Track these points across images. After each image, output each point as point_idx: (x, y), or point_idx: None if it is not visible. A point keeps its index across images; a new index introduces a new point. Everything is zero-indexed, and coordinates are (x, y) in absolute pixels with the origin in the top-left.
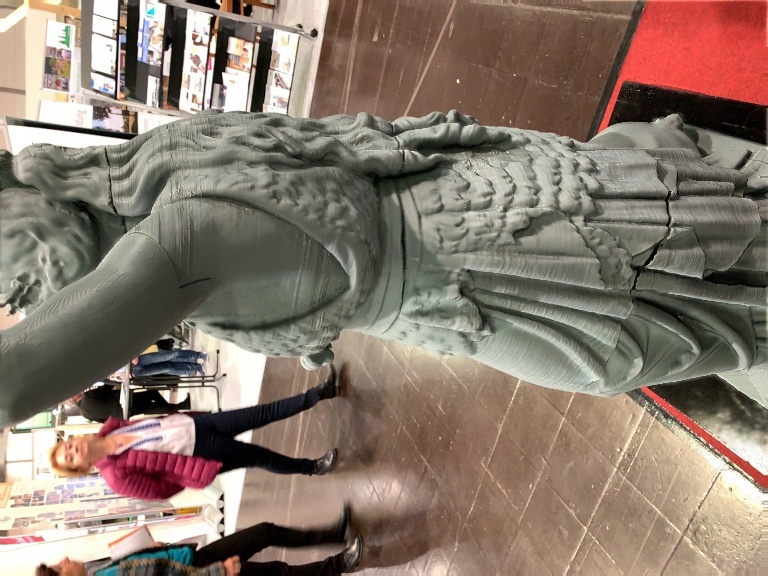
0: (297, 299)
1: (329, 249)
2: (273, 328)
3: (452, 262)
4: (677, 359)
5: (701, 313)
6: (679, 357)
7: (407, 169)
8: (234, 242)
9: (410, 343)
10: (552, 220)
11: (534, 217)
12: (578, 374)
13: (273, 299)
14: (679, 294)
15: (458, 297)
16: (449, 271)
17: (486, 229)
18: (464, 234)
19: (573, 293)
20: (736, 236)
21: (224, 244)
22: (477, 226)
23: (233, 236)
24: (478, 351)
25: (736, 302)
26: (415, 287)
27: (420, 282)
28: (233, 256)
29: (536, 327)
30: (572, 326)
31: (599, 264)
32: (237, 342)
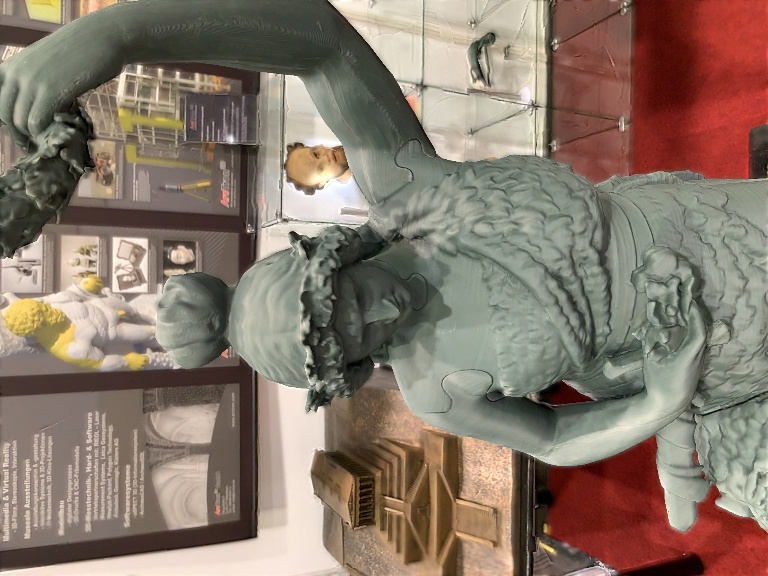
0: None
1: None
2: None
3: None
4: None
5: None
6: None
7: None
8: None
9: (666, 200)
10: None
11: None
12: None
13: None
14: None
15: None
16: None
17: None
18: None
19: None
20: None
21: None
22: None
23: None
24: None
25: None
26: None
27: None
28: None
29: None
30: None
31: None
32: (503, 168)
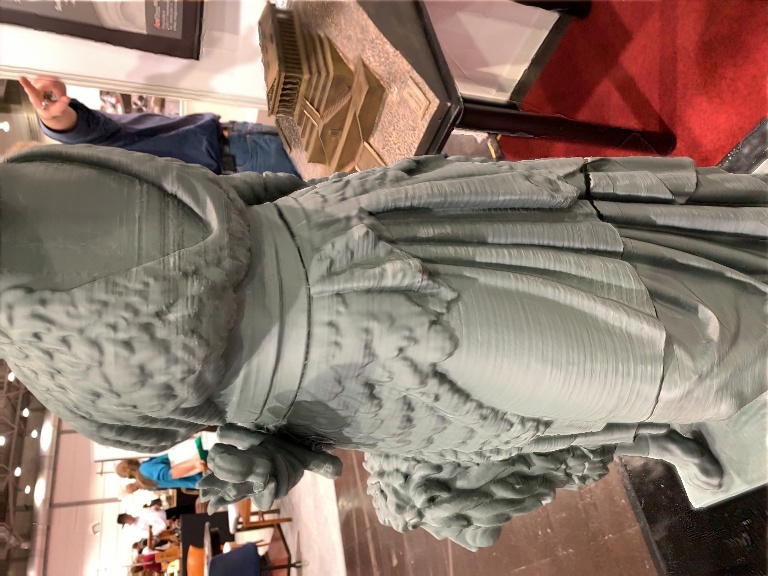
0: (141, 250)
1: (170, 185)
2: (105, 277)
3: (345, 208)
4: (762, 313)
5: (727, 252)
6: (762, 311)
7: (271, 184)
8: (39, 177)
9: (352, 345)
10: (443, 164)
11: (418, 161)
12: (632, 341)
13: (105, 253)
14: (666, 220)
15: (369, 233)
16: (346, 217)
17: (368, 174)
18: (346, 184)
19: (524, 222)
20: (673, 167)
21: (25, 177)
22: (357, 175)
23: (38, 174)
24: (459, 337)
25: (750, 225)
26: (314, 248)
27: (317, 241)
28: (38, 189)
29: (512, 278)
30: (561, 271)
31: (522, 175)
32: (57, 324)
